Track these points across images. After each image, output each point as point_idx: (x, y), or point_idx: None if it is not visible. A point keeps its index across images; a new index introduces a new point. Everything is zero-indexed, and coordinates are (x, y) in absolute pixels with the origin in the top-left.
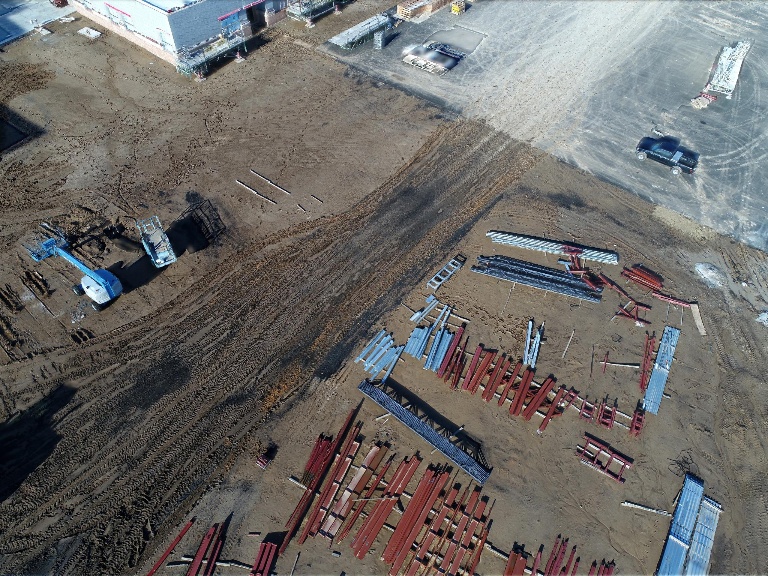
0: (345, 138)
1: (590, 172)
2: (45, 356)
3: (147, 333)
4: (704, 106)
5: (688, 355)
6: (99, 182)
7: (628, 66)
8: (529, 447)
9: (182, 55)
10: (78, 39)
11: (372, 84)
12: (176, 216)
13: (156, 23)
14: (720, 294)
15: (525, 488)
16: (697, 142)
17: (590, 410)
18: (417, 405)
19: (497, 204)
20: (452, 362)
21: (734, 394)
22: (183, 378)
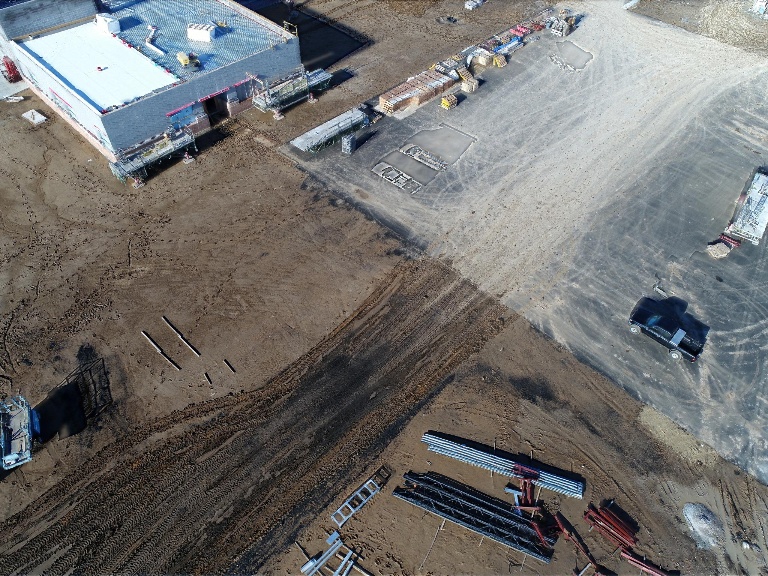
0: (283, 277)
1: (568, 348)
2: None
3: None
4: (723, 255)
5: None
6: None
7: (637, 191)
8: None
9: None
10: (20, 124)
11: (330, 201)
12: (59, 380)
13: (93, 121)
14: (711, 560)
15: None
16: (708, 309)
17: None
18: None
19: (445, 389)
20: None
21: None
22: None
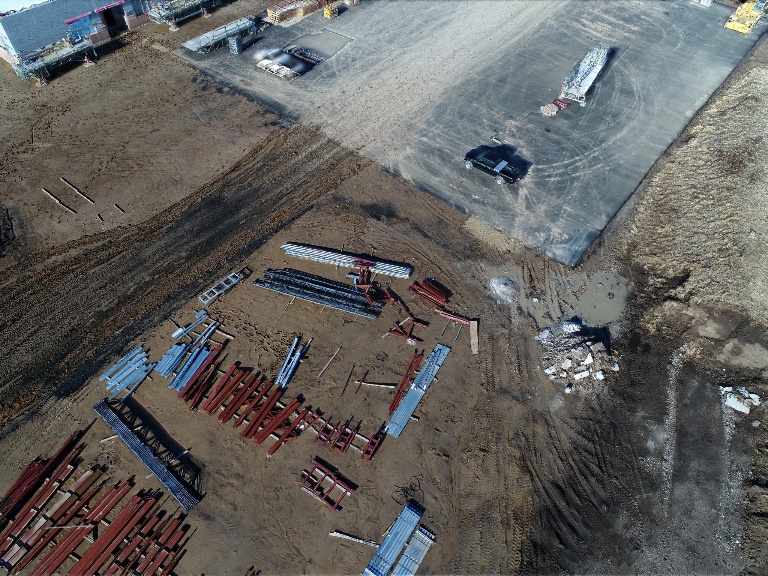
0: (171, 145)
1: (411, 182)
2: None
3: None
4: (553, 113)
5: (451, 375)
6: None
7: (488, 72)
8: (252, 472)
9: None
10: None
11: (217, 89)
12: None
13: None
14: (506, 310)
15: (233, 516)
16: (534, 151)
17: (328, 433)
18: (149, 426)
19: (304, 215)
20: (199, 381)
21: (487, 416)
22: None
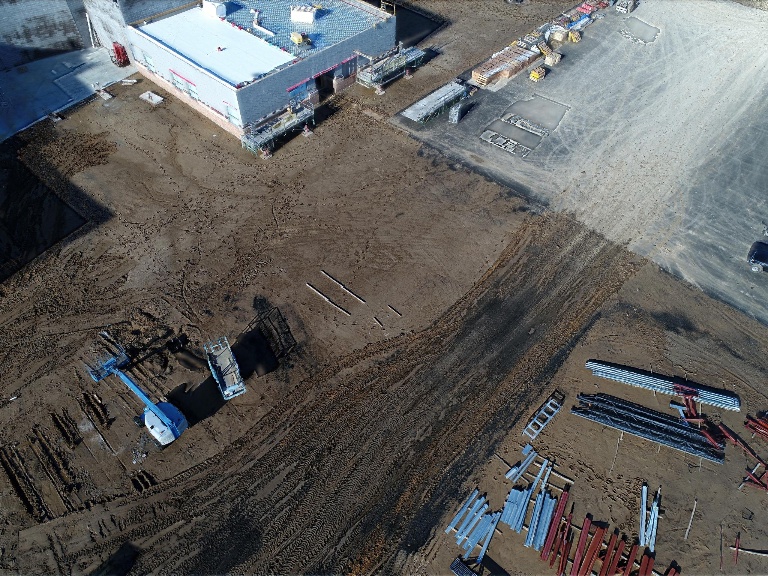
0: (422, 233)
1: (698, 286)
2: (104, 506)
3: (214, 481)
4: None
5: None
6: (161, 281)
7: (729, 149)
8: None
9: (248, 129)
10: (140, 105)
11: (449, 166)
12: (243, 327)
13: (223, 97)
14: None
15: None
16: None
17: None
18: None
19: (595, 325)
20: (558, 540)
21: None
22: (254, 544)
